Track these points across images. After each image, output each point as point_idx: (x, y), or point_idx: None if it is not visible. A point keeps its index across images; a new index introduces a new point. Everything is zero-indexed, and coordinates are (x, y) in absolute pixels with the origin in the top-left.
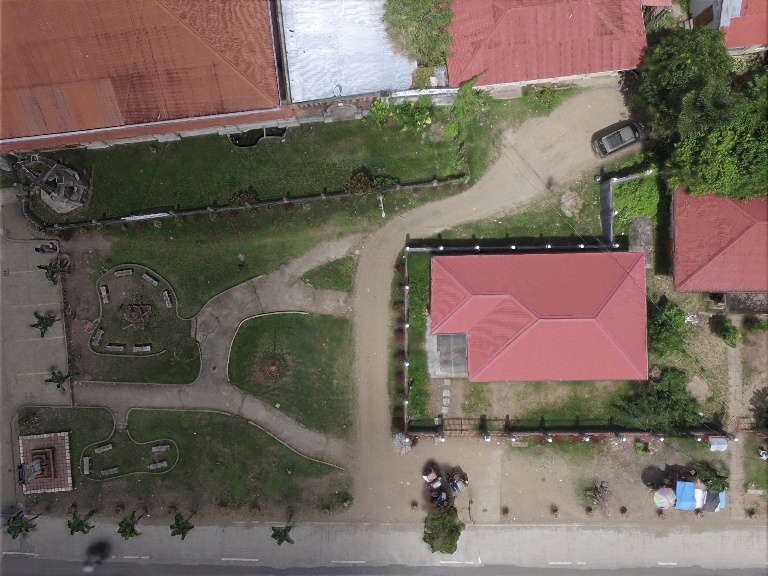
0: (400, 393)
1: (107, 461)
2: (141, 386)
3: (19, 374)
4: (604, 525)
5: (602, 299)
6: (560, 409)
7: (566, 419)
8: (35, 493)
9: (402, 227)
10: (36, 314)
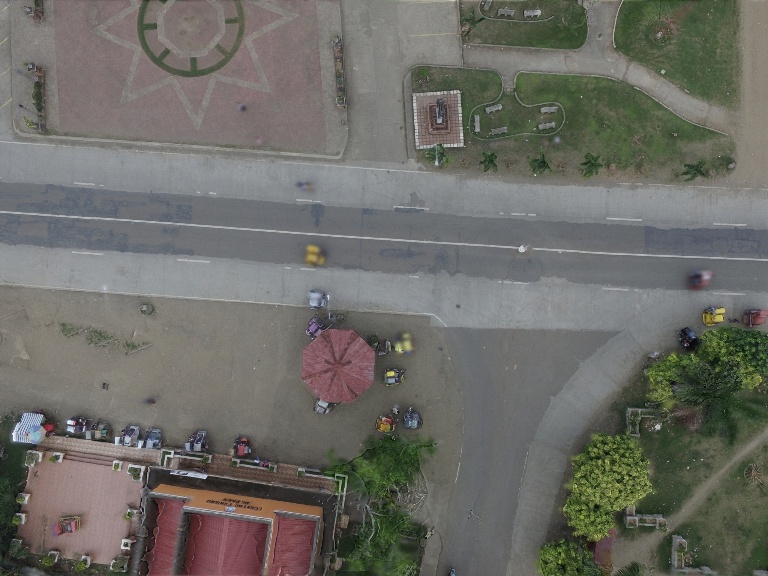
0: None
1: (494, 122)
2: (528, 51)
3: (412, 35)
4: None
5: None
6: None
7: None
8: (427, 148)
9: None
10: None
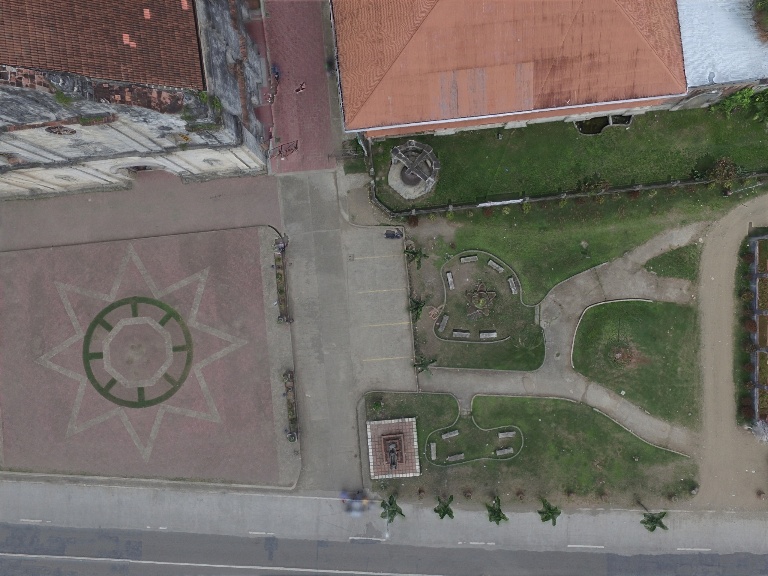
0: (750, 381)
1: (451, 447)
2: (485, 372)
3: (365, 359)
4: None
5: None
6: None
7: None
8: (383, 478)
9: (745, 216)
10: (413, 298)
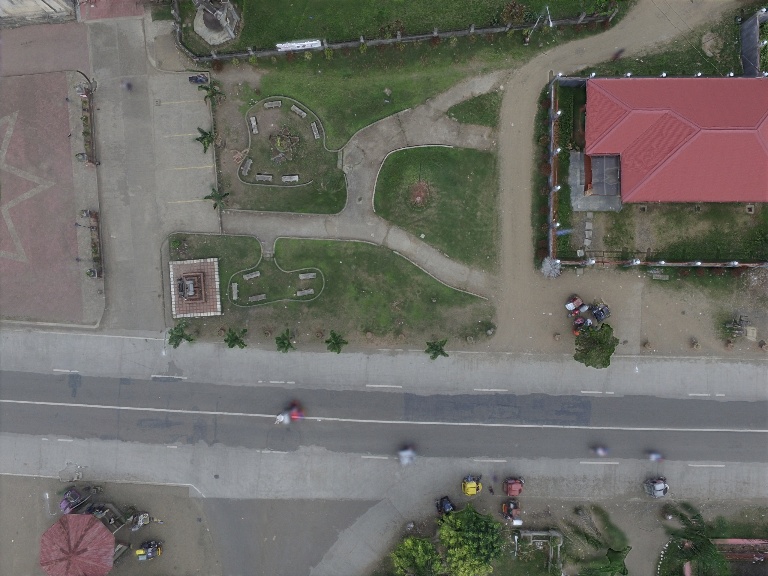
0: (545, 223)
1: (254, 288)
2: (288, 216)
3: (169, 202)
4: (743, 358)
5: (761, 114)
6: (701, 243)
7: (707, 252)
8: (184, 317)
9: (546, 64)
10: (200, 129)
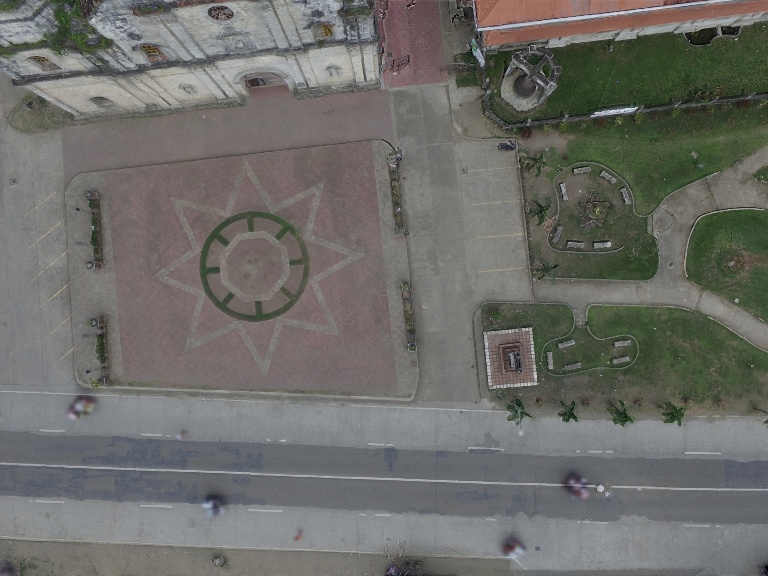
0: None
1: (567, 357)
2: (599, 282)
3: (480, 271)
4: None
5: None
6: None
7: None
8: (500, 388)
9: None
10: (537, 202)
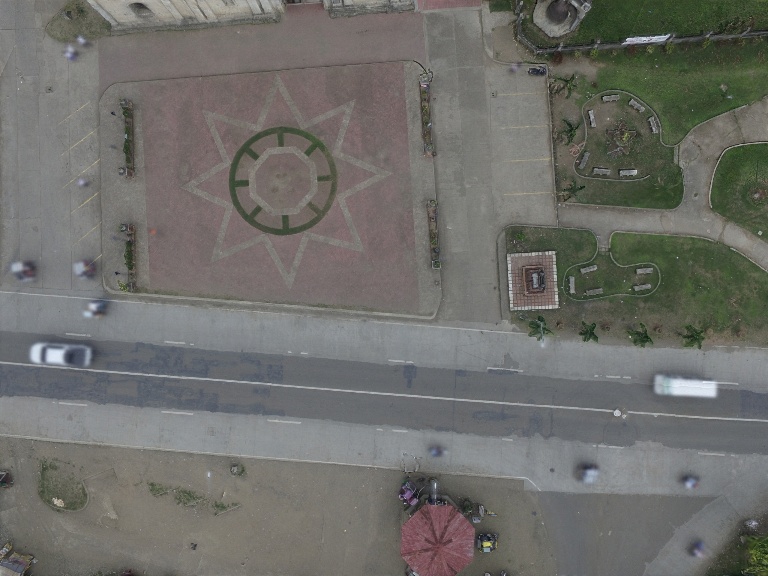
0: None
1: (589, 282)
2: (624, 210)
3: (506, 194)
4: None
5: None
6: None
7: None
8: (522, 310)
9: None
10: (567, 121)
